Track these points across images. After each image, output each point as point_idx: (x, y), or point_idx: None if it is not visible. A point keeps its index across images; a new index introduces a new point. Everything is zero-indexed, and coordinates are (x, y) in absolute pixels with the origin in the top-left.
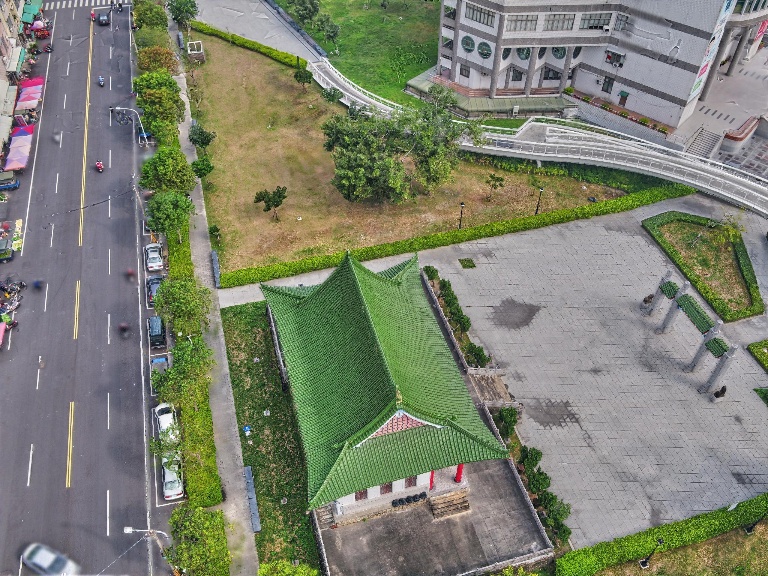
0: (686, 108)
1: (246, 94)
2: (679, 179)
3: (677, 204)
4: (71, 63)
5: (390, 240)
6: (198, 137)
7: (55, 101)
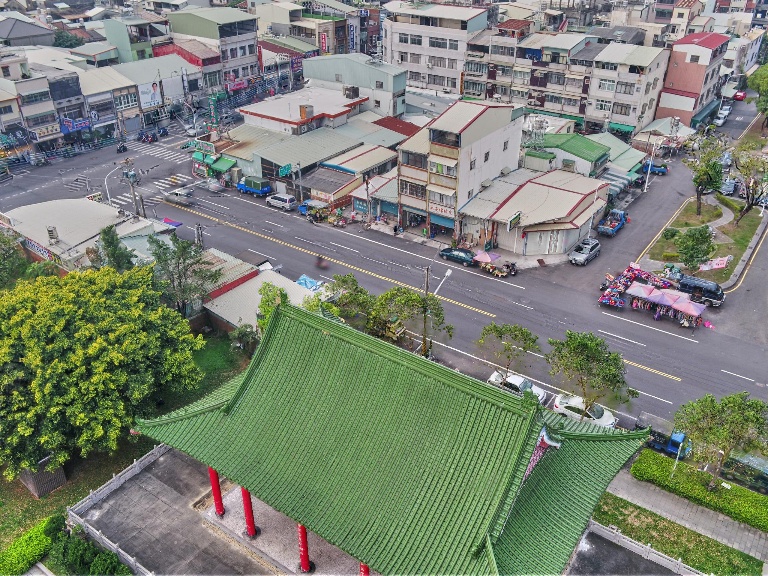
0: None
1: None
2: None
3: None
4: None
5: None
6: None
7: None
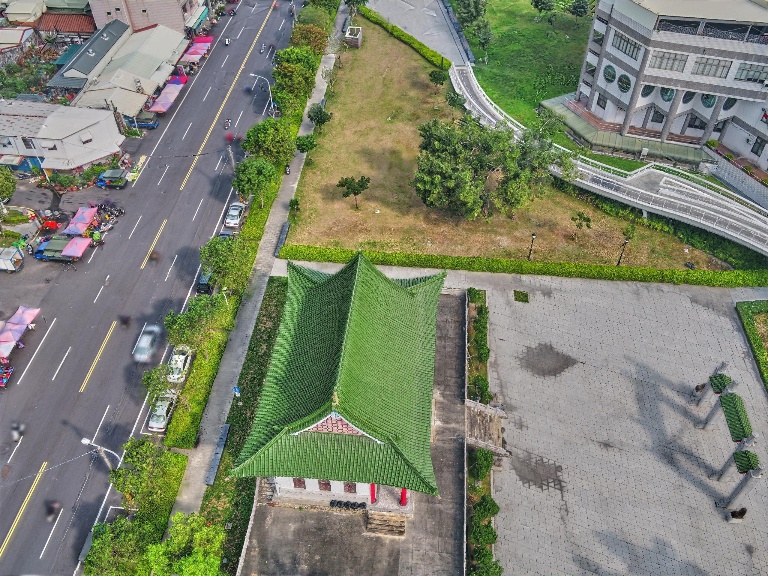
0: None
1: (382, 84)
2: None
3: None
4: (245, 28)
5: (455, 254)
6: (314, 115)
7: (217, 59)
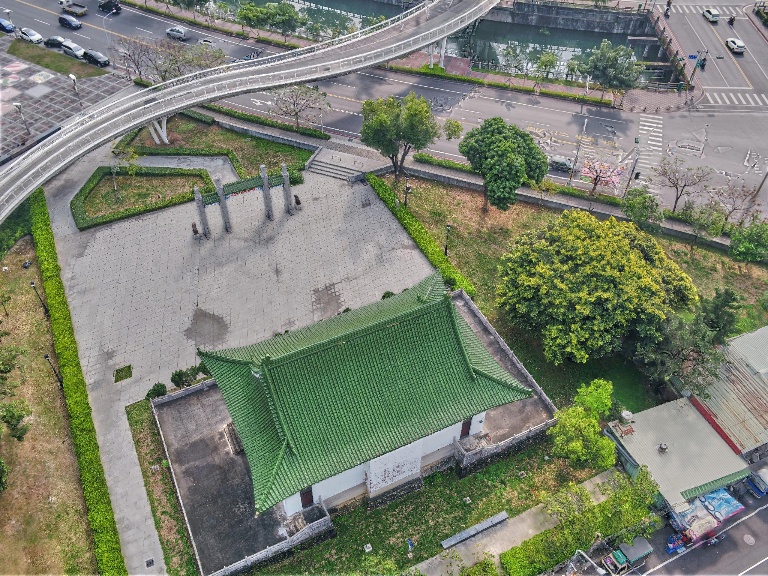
0: None
1: None
2: None
3: (56, 201)
4: None
5: (64, 464)
6: None
7: None
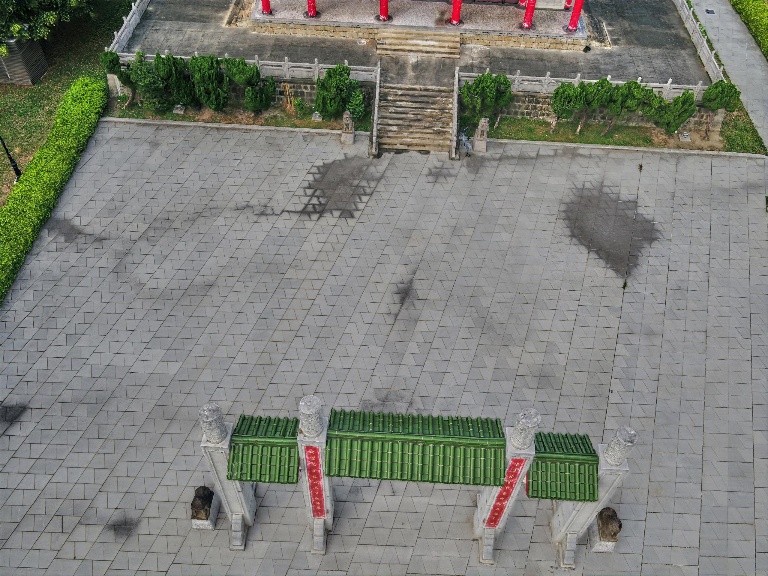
0: None
1: None
2: None
3: None
4: None
5: None
6: None
7: None
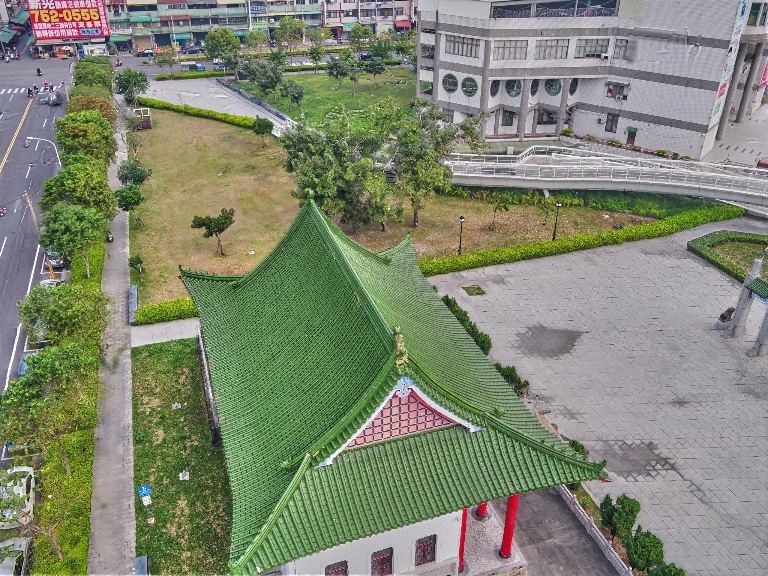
0: (707, 136)
1: (196, 150)
2: (724, 191)
3: (724, 226)
4: None
5: None
6: (129, 172)
7: None
